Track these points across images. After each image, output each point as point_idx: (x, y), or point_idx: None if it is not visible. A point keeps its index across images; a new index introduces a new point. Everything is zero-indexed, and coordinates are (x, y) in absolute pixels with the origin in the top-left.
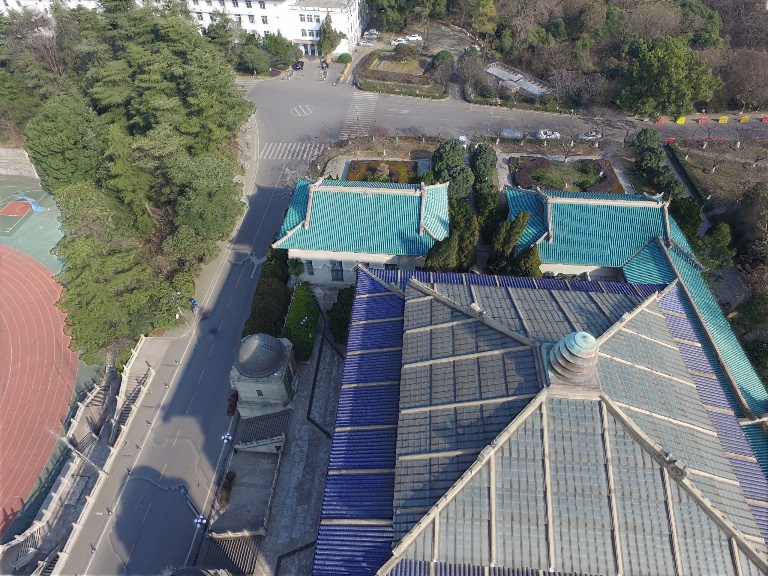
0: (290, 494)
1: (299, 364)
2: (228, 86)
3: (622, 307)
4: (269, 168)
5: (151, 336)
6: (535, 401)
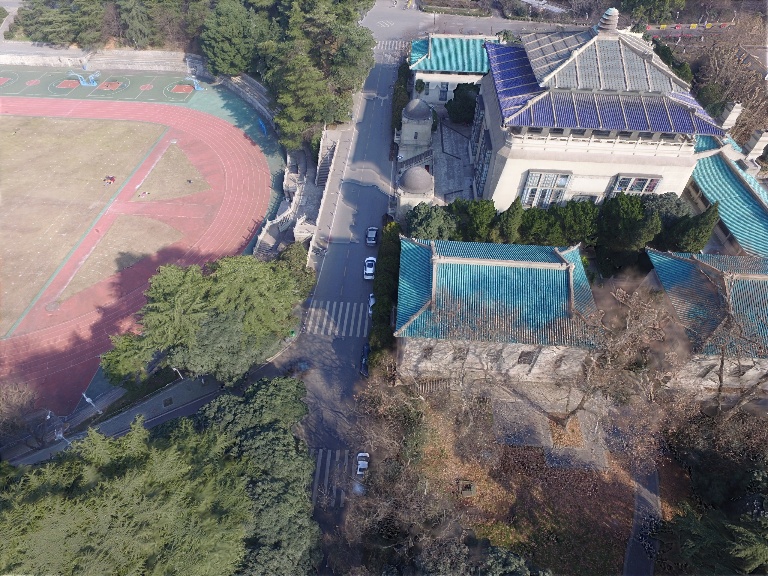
0: (443, 176)
1: (431, 132)
2: None
3: None
4: None
5: (329, 129)
6: (592, 39)
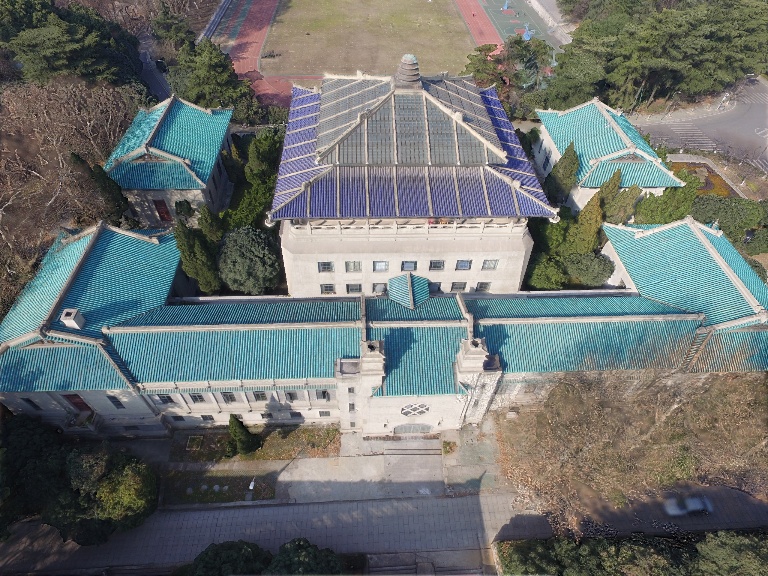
0: None
1: None
2: (690, 46)
3: None
4: (658, 130)
5: None
6: None
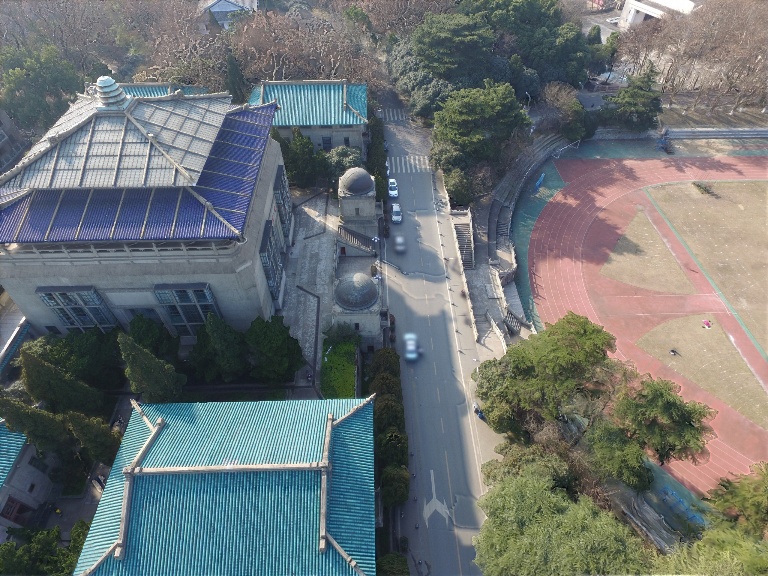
0: (324, 257)
1: None
2: None
3: (37, 168)
4: None
5: None
6: None
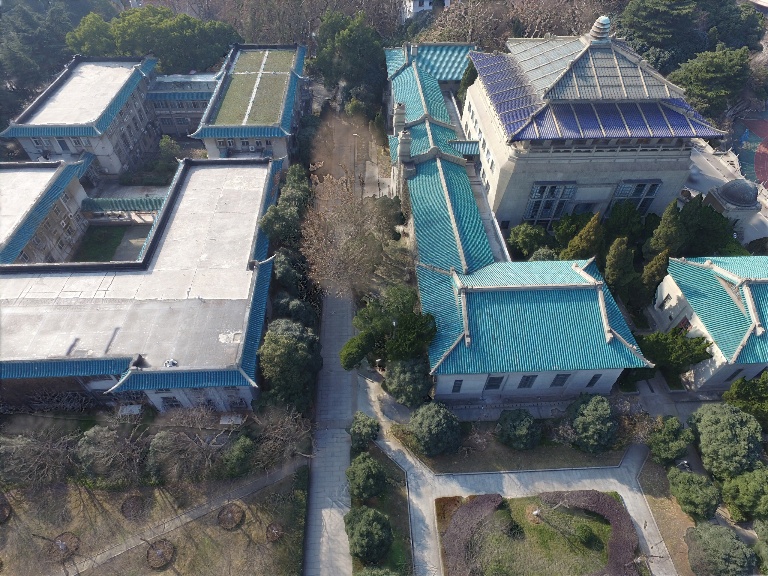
0: None
1: None
2: None
3: (564, 85)
4: None
5: None
6: None
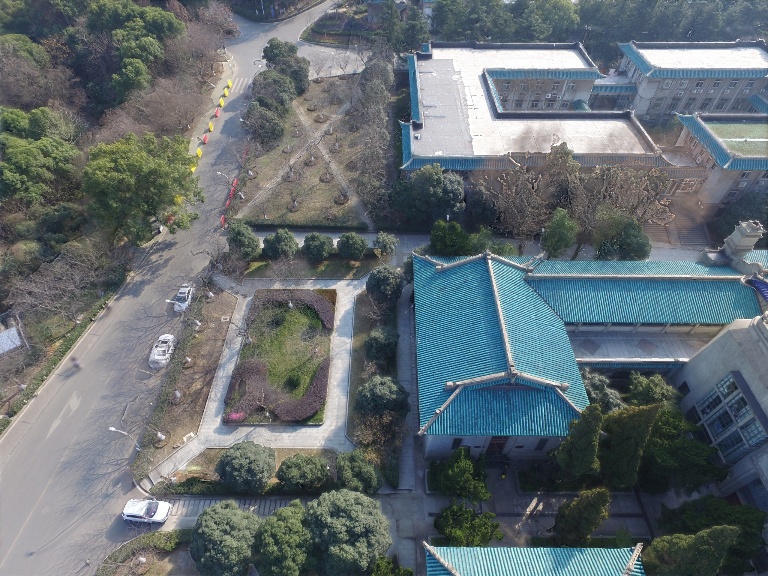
0: None
1: None
2: None
3: None
4: None
5: None
6: None
